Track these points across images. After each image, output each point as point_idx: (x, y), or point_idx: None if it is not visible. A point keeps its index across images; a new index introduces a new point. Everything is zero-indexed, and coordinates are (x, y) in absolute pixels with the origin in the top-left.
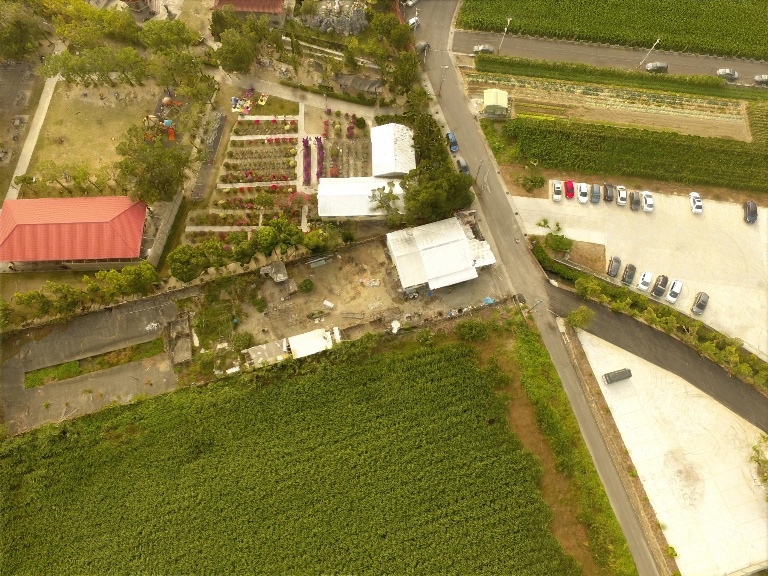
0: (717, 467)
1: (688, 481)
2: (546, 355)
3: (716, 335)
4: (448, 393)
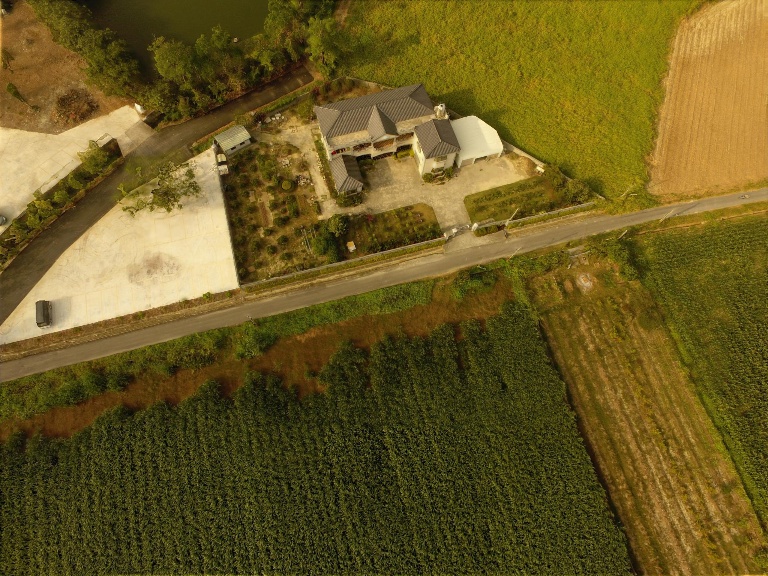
0: (151, 239)
1: (158, 267)
2: (1, 387)
3: (29, 210)
4: (8, 513)
